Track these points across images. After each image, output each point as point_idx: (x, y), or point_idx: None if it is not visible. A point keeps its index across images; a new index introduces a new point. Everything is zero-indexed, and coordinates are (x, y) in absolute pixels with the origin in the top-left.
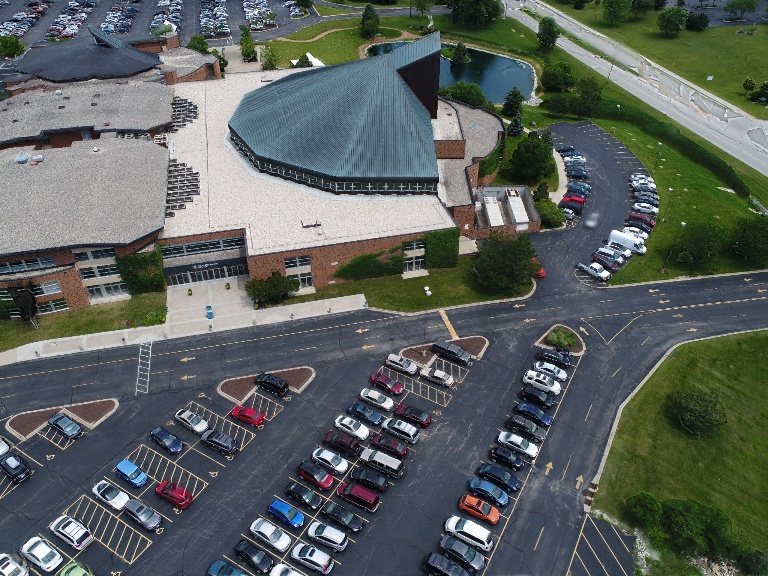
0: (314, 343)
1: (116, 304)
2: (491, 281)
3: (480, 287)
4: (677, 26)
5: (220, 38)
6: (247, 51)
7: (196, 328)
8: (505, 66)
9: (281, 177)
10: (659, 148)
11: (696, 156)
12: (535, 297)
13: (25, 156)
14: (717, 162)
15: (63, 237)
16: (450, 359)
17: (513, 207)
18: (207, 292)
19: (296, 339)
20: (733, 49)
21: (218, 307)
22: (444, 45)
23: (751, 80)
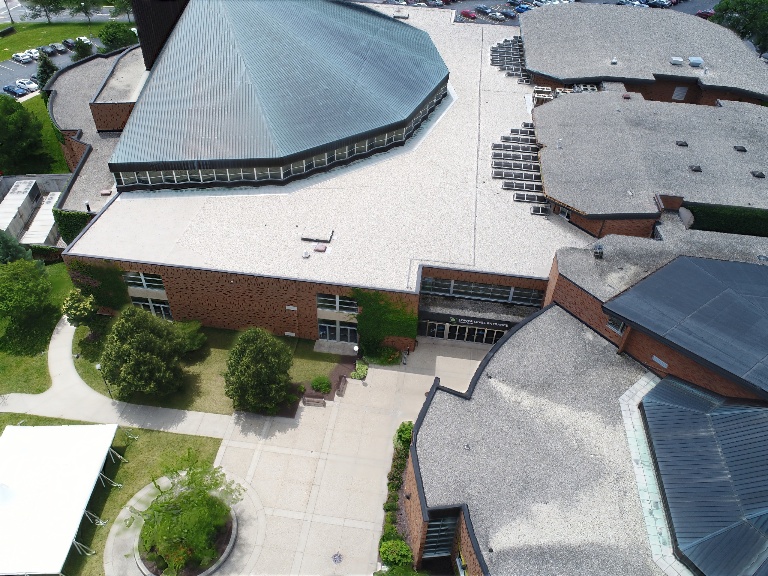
0: None
1: None
2: None
3: None
4: None
5: None
6: None
7: None
8: None
9: None
10: None
11: None
12: None
13: (693, 59)
14: None
15: (592, 6)
16: None
17: None
18: None
19: None
20: None
21: None
22: None
23: None
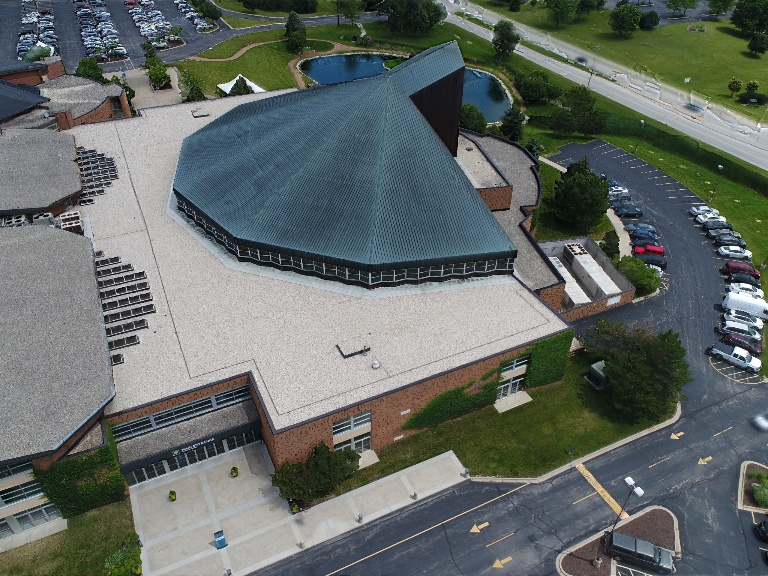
0: (413, 571)
1: (41, 545)
2: (638, 406)
3: (610, 410)
4: (632, 25)
5: (115, 61)
6: (158, 76)
7: (201, 575)
8: None
9: (276, 267)
10: (691, 167)
11: (734, 174)
12: (687, 415)
13: None
14: (762, 180)
15: None
16: (640, 565)
17: (589, 271)
18: (201, 489)
19: (381, 567)
20: (695, 48)
21: (228, 519)
22: (385, 57)
23: (738, 80)
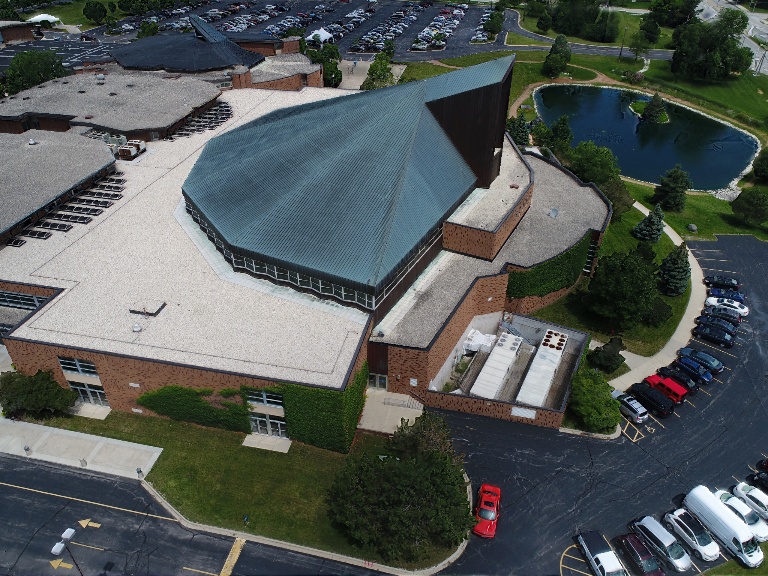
0: (4, 516)
1: None
2: (346, 520)
3: None
4: None
5: (368, 53)
6: (373, 68)
7: None
8: (722, 137)
9: None
10: None
11: None
12: None
13: None
14: None
15: None
16: None
17: (533, 368)
18: None
19: None
20: None
21: None
22: (647, 97)
23: None
